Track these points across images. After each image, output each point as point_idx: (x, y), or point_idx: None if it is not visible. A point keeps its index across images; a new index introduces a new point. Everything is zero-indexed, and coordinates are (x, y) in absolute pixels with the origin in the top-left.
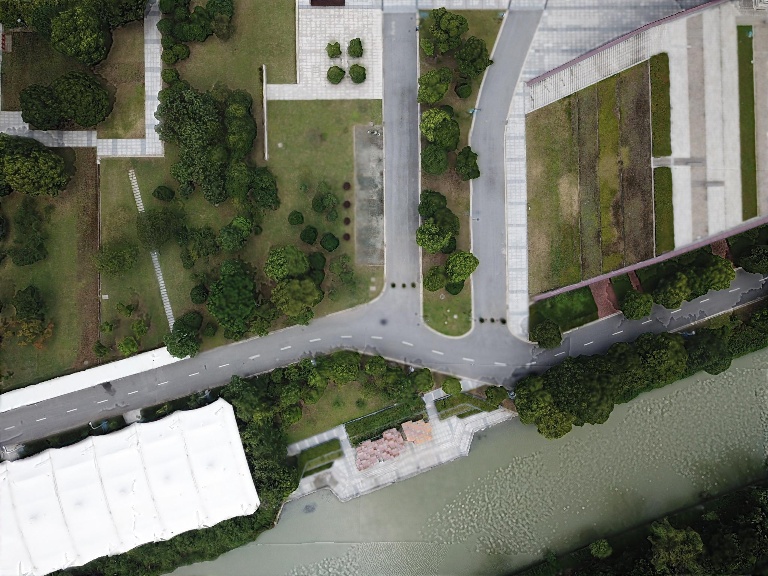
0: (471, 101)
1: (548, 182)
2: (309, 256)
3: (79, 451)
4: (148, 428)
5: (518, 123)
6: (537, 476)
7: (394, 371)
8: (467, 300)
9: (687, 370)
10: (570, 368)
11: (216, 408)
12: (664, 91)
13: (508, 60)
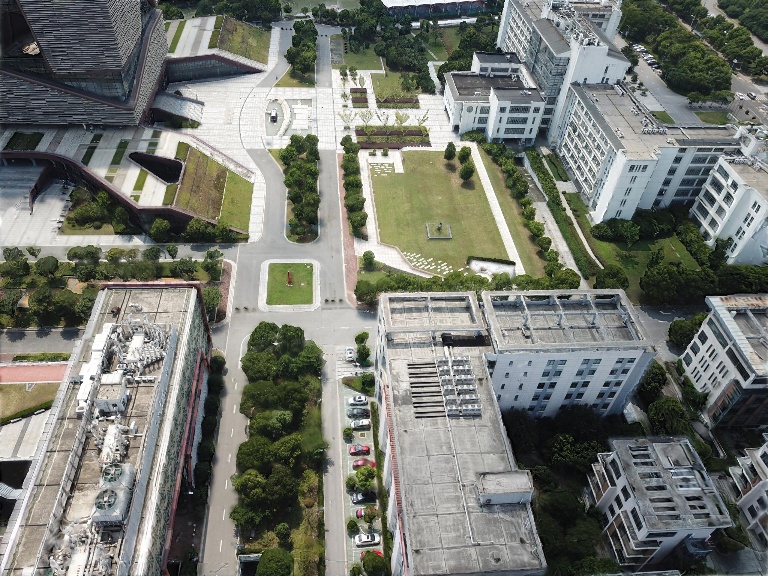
0: None
1: (260, 48)
2: (360, 36)
3: (435, 1)
4: (413, 4)
5: (271, 63)
6: None
7: (326, 11)
8: None
9: None
10: (261, 5)
11: (390, 5)
12: None
13: None
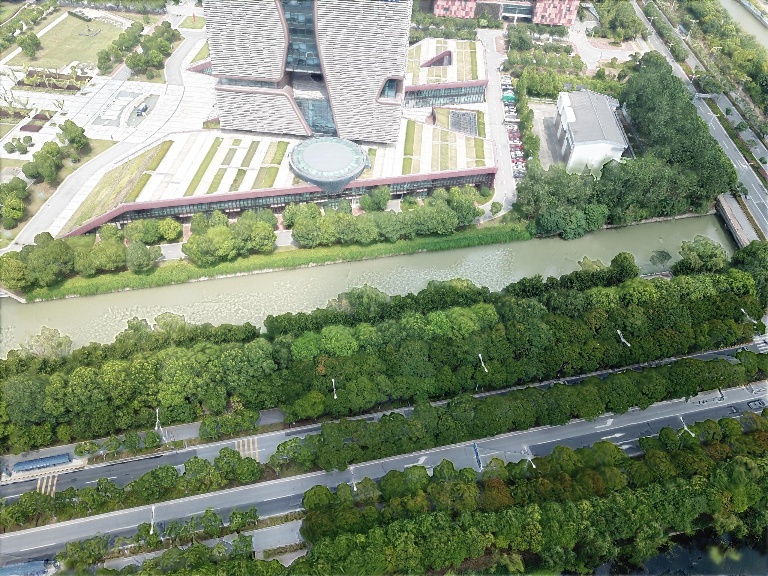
0: (78, 165)
1: (97, 192)
2: None
3: None
4: None
5: (99, 175)
6: (6, 345)
7: None
8: (14, 234)
9: (136, 279)
10: None
11: None
12: (164, 150)
13: (110, 156)
